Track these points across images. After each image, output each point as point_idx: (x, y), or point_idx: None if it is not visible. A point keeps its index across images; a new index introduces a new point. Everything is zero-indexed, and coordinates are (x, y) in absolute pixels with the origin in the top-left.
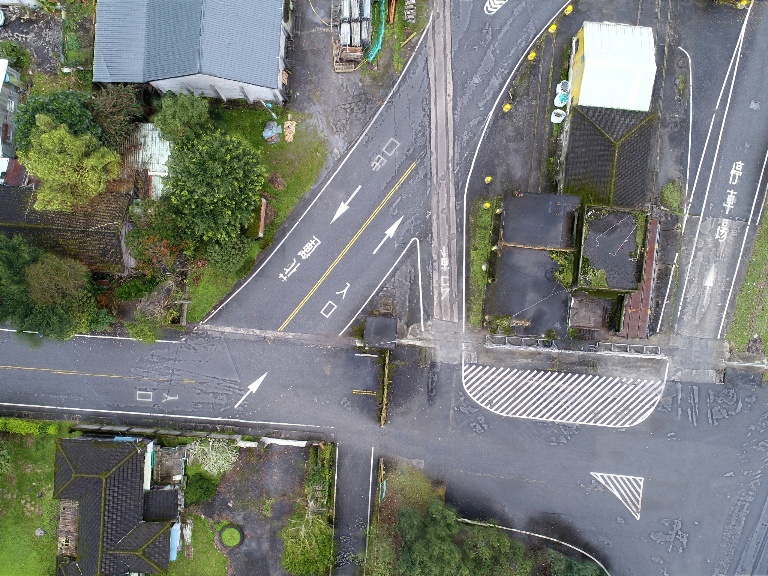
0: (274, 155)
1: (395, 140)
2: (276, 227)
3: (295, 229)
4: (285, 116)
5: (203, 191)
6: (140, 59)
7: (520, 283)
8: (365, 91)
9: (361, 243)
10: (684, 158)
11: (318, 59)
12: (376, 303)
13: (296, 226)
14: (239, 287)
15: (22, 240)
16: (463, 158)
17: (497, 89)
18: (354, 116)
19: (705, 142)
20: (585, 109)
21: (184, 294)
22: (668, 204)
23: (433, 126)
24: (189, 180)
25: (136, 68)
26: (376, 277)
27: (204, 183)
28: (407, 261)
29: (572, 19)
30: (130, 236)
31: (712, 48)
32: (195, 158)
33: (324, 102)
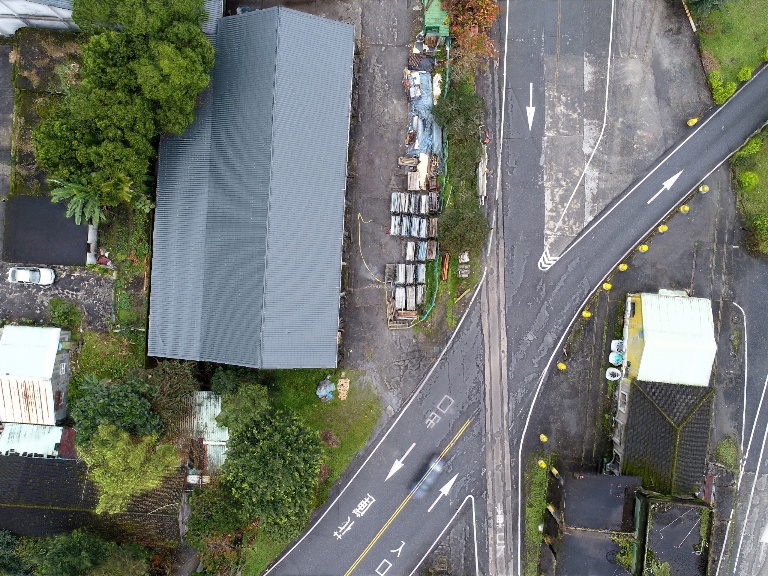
0: (328, 413)
1: (449, 397)
2: (330, 485)
3: (349, 487)
4: (339, 374)
5: (264, 486)
6: (196, 337)
7: (581, 565)
8: (419, 348)
9: (416, 501)
10: (739, 414)
11: (371, 316)
12: (431, 561)
13: (350, 484)
14: (293, 545)
15: (82, 536)
16: (518, 415)
17: (551, 346)
18: (408, 373)
19: (760, 398)
20: (644, 385)
21: (239, 559)
22: (723, 460)
23: (487, 382)
24: (250, 475)
25: (192, 346)
26: (431, 535)
27: (265, 476)
28: (462, 519)
29: (626, 274)
30: (191, 530)
31: (767, 304)
32: (256, 452)
33: (378, 359)
